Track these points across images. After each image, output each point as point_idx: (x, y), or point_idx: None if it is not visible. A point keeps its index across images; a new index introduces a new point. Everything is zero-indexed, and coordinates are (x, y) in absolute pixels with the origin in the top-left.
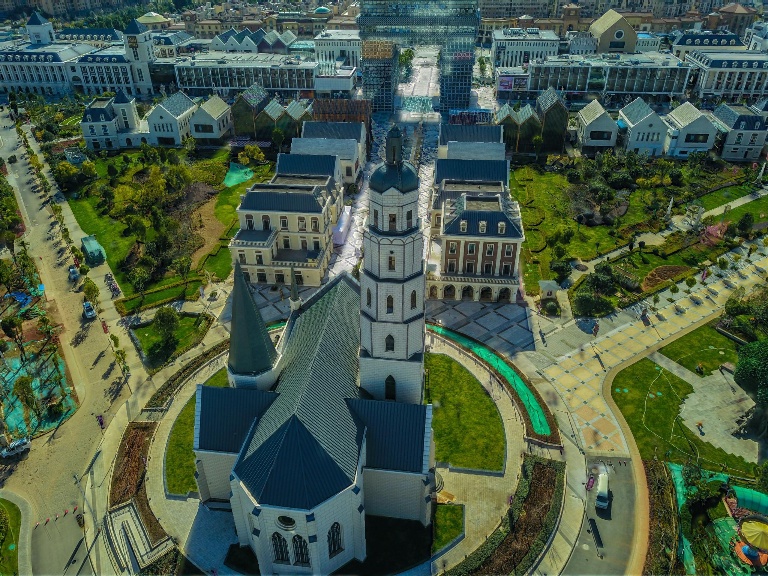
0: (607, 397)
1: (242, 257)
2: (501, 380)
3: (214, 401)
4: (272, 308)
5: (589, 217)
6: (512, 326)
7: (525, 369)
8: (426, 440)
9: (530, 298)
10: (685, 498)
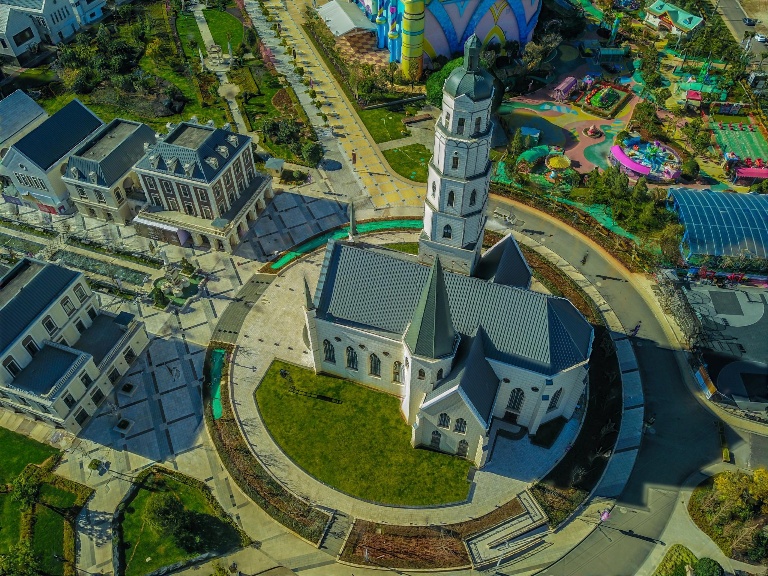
0: (417, 184)
1: (68, 400)
2: (382, 231)
3: (469, 384)
4: (169, 395)
5: (171, 105)
6: (308, 207)
7: (370, 216)
8: (521, 256)
9: (272, 184)
10: (517, 184)
